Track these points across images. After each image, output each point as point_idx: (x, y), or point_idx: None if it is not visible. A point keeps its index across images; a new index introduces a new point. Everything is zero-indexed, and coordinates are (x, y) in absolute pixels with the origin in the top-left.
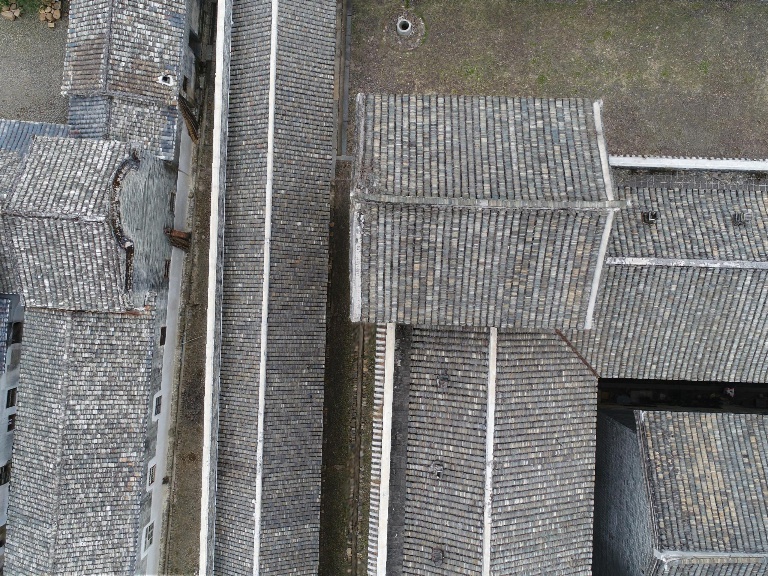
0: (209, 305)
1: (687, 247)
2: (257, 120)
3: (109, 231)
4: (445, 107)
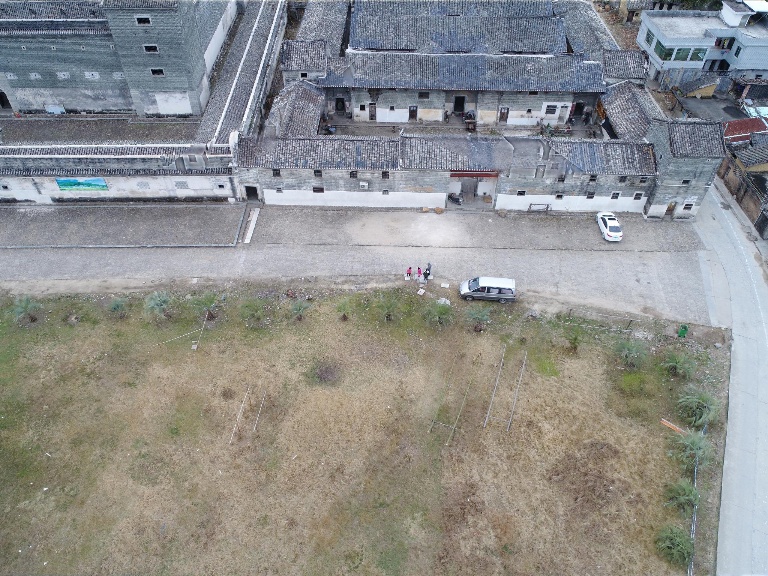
0: (265, 54)
1: (84, 6)
2: None
3: None
4: (150, 3)
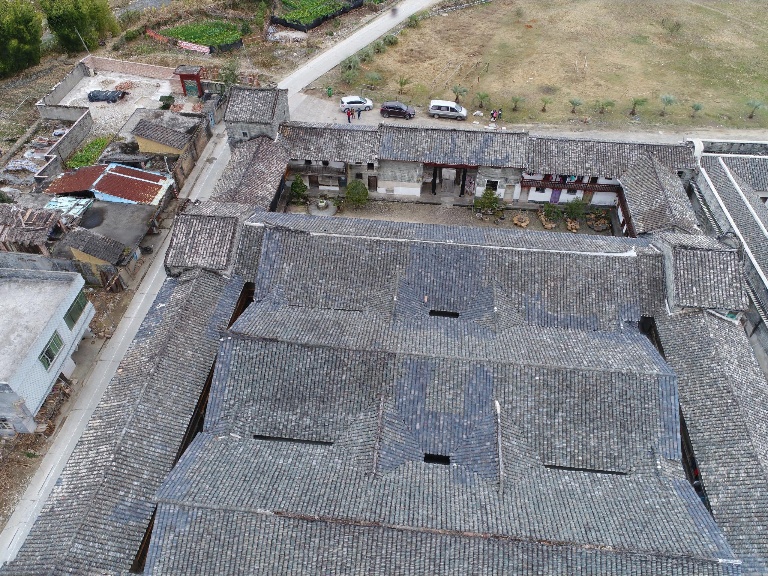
0: None
1: None
2: (760, 243)
3: (737, 258)
4: None
